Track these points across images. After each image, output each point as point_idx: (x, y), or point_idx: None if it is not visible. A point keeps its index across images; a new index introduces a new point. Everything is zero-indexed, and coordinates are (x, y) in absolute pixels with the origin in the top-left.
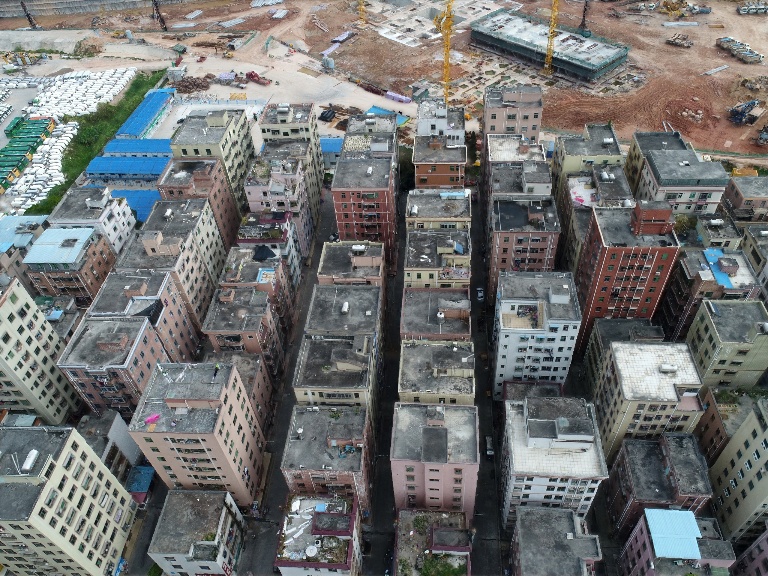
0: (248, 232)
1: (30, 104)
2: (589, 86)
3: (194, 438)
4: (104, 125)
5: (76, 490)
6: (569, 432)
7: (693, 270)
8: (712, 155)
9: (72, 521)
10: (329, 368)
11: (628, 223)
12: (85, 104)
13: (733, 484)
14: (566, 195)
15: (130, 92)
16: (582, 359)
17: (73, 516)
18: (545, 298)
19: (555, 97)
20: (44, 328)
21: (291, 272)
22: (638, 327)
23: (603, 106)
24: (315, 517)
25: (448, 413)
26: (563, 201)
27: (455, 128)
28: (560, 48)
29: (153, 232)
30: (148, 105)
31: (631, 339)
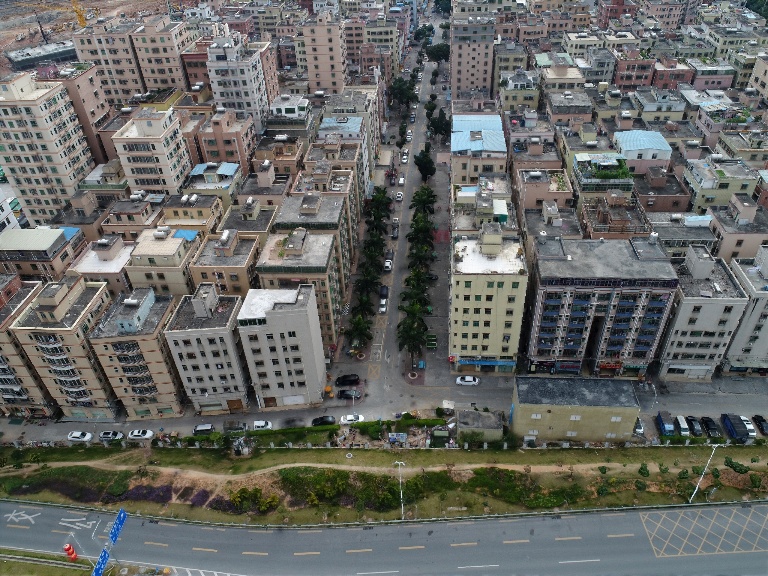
0: None
1: None
2: None
3: None
4: None
5: None
6: None
7: None
8: None
9: None
10: None
11: None
12: None
13: None
14: None
15: None
16: None
17: None
18: None
19: None
20: None
21: None
22: None
23: None
24: None
25: None
26: None
27: None
28: None
29: (263, 32)
30: None
31: None
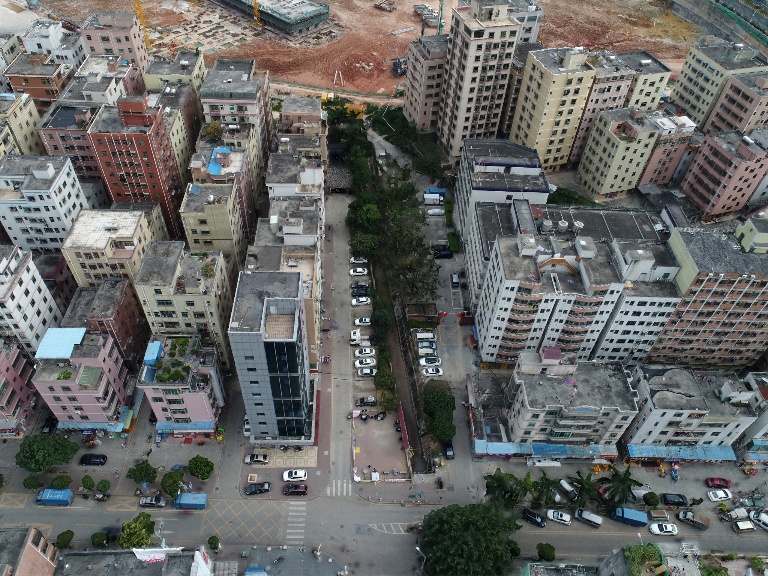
0: None
1: None
2: (289, 38)
3: None
4: None
5: None
6: None
7: None
8: (340, 94)
9: None
10: None
11: None
12: None
13: None
14: None
15: None
16: None
17: None
18: None
19: (255, 46)
20: None
21: None
22: (136, 206)
23: (293, 56)
24: None
25: None
26: None
27: None
28: (269, 3)
29: None
30: None
31: None
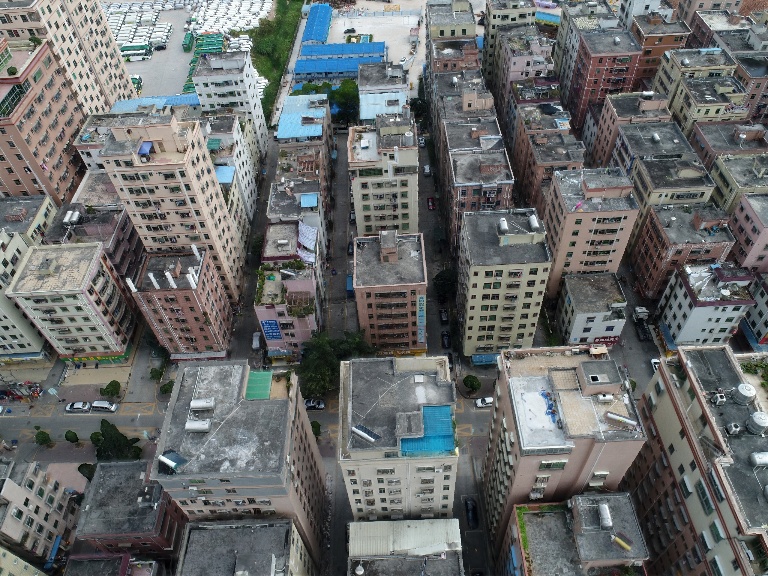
0: (530, 93)
1: (188, 23)
2: None
3: (619, 216)
4: (273, 38)
5: None
6: None
7: None
8: None
9: None
10: (672, 177)
11: None
12: (245, 20)
13: None
14: None
15: (280, 9)
16: None
17: None
18: None
19: (672, 3)
20: None
21: None
22: None
23: None
24: (720, 270)
25: None
26: None
27: None
28: None
29: (470, 88)
30: (319, 16)
31: None
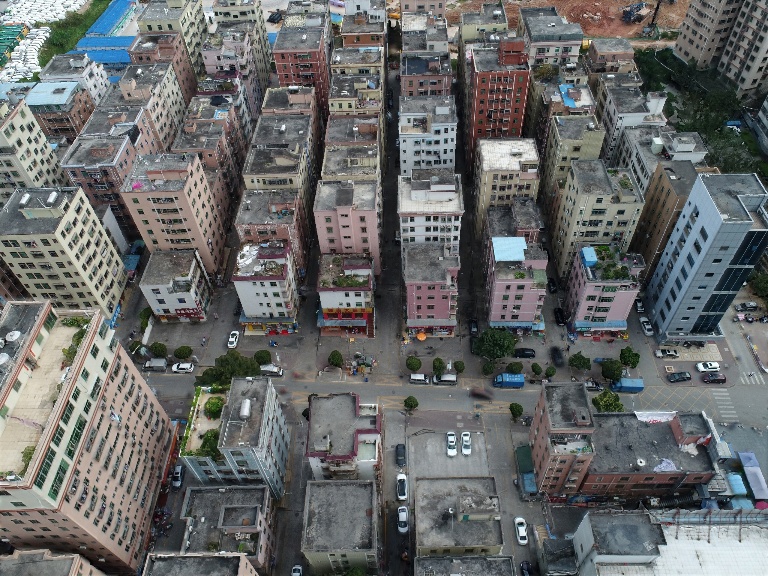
0: (206, 85)
1: (2, 14)
2: None
3: (169, 197)
4: (73, 30)
5: (84, 233)
6: (438, 184)
7: (549, 98)
8: None
9: (83, 253)
10: (270, 164)
11: (497, 59)
12: (54, 12)
13: (562, 233)
14: (463, 57)
15: (95, 3)
16: (472, 178)
17: (83, 251)
18: (432, 112)
19: (477, 5)
20: (46, 147)
21: (243, 123)
22: None
23: None
24: (260, 248)
25: (357, 186)
26: (462, 63)
27: (377, 9)
28: None
29: (128, 79)
30: (113, 10)
31: None
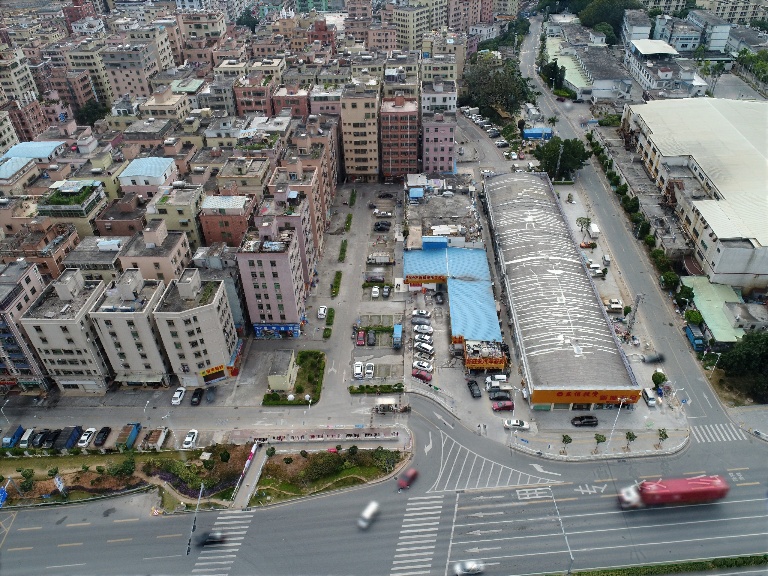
0: None
1: None
2: None
3: None
4: None
5: None
6: (134, 21)
7: None
8: None
9: None
10: None
11: None
12: None
13: None
14: None
15: None
16: None
17: None
18: None
19: None
20: None
21: None
22: None
23: None
24: None
25: None
26: None
27: None
28: None
29: None
30: None
31: (108, 33)
